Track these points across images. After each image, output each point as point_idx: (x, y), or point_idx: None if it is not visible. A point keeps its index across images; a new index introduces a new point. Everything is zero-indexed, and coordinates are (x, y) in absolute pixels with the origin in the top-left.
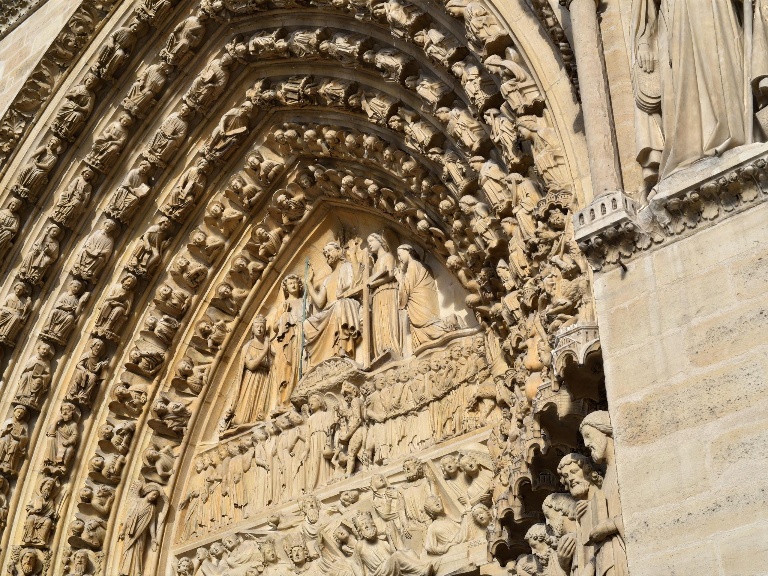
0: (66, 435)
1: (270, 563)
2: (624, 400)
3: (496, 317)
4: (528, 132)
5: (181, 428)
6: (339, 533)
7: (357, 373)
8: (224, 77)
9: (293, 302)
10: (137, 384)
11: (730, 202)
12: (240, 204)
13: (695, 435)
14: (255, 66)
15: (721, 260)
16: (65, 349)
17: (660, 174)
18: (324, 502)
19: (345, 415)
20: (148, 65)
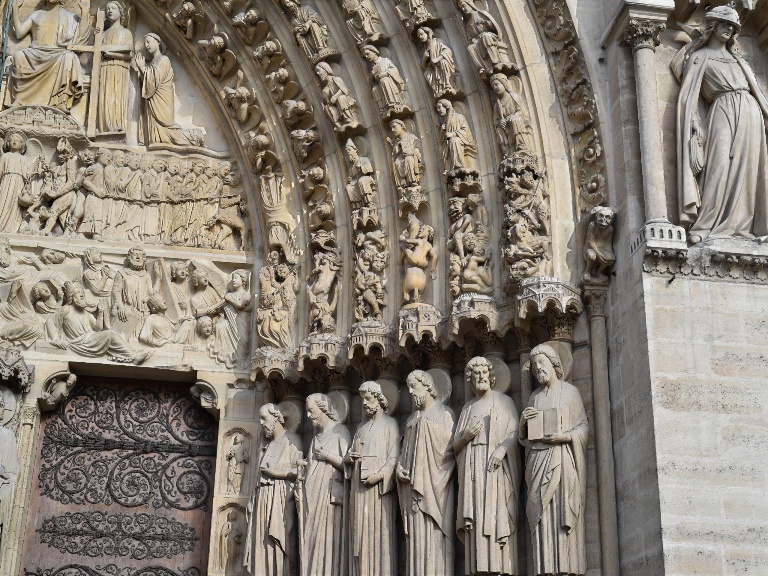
0: None
1: None
2: (663, 375)
3: (315, 179)
4: (504, 89)
5: None
6: (43, 289)
7: (83, 138)
8: None
9: None
10: None
11: (750, 274)
12: None
13: (712, 418)
14: None
15: (739, 309)
16: None
17: (700, 226)
18: (12, 248)
19: (53, 171)
20: None
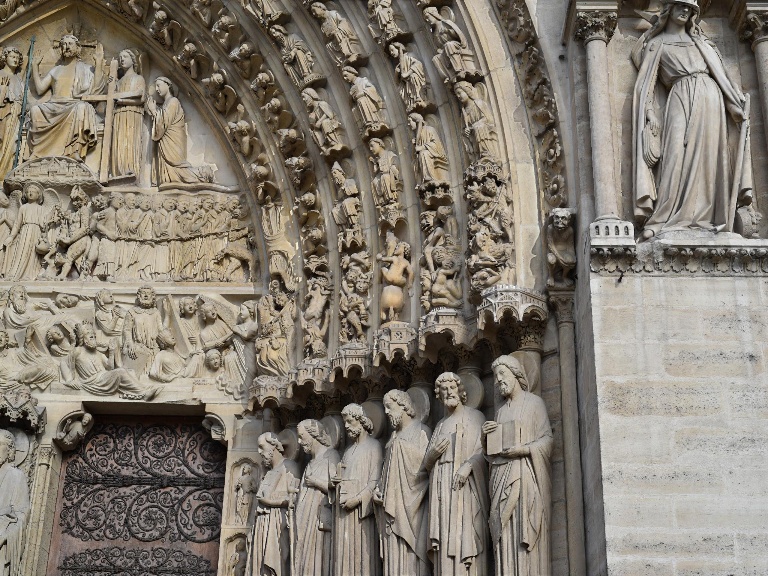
0: None
1: None
2: (610, 379)
3: (306, 205)
4: (467, 97)
5: None
6: (56, 333)
7: (95, 184)
8: None
9: (10, 76)
10: None
11: (709, 266)
12: None
13: (664, 422)
14: None
15: (696, 305)
16: None
17: (654, 219)
18: (30, 295)
19: (68, 218)
20: None
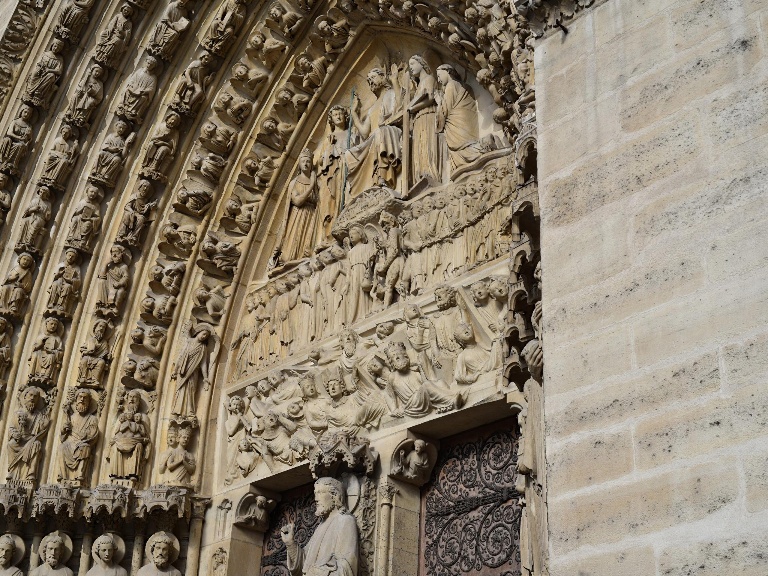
0: (117, 277)
1: (310, 398)
2: (553, 177)
3: (515, 128)
4: None
5: (231, 268)
6: (372, 365)
7: (394, 202)
8: None
9: (339, 134)
10: (186, 225)
11: None
12: (282, 34)
13: (620, 208)
14: None
15: (662, 8)
16: (114, 191)
17: None
18: (362, 335)
19: (384, 246)
20: None
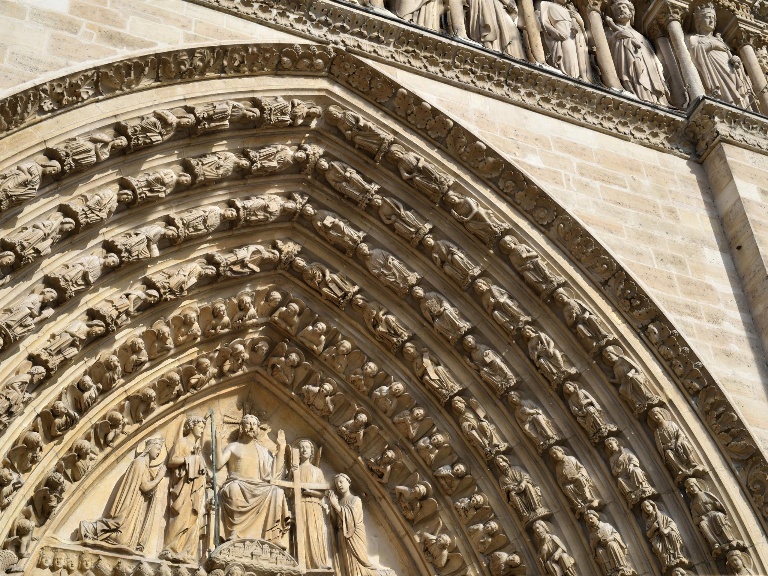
0: None
1: None
2: None
3: None
4: (742, 565)
5: None
6: None
7: (300, 574)
8: (276, 216)
9: None
10: None
11: None
12: (202, 324)
13: None
14: (297, 227)
15: None
16: (2, 353)
17: None
18: None
19: None
20: (228, 149)
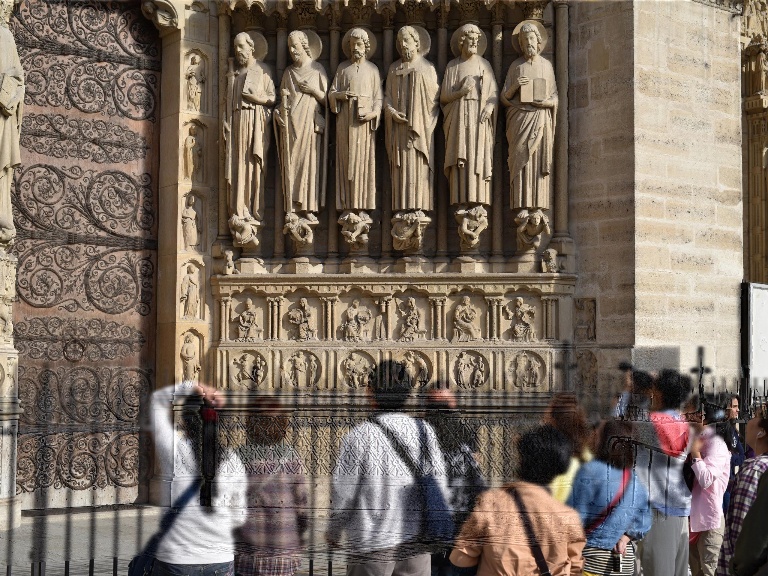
0: None
1: None
2: None
3: None
4: None
5: None
6: None
7: None
8: None
9: None
10: None
11: None
12: None
13: (665, 103)
14: None
15: None
16: None
17: None
18: None
19: None
20: None
